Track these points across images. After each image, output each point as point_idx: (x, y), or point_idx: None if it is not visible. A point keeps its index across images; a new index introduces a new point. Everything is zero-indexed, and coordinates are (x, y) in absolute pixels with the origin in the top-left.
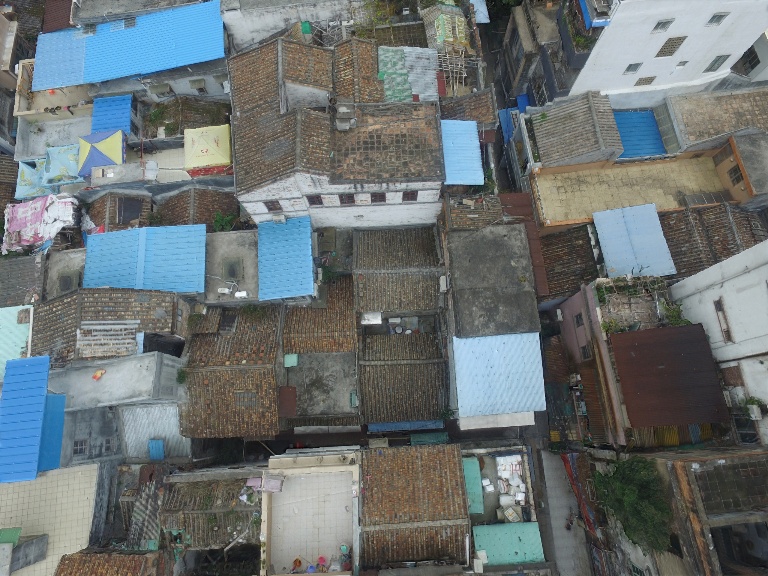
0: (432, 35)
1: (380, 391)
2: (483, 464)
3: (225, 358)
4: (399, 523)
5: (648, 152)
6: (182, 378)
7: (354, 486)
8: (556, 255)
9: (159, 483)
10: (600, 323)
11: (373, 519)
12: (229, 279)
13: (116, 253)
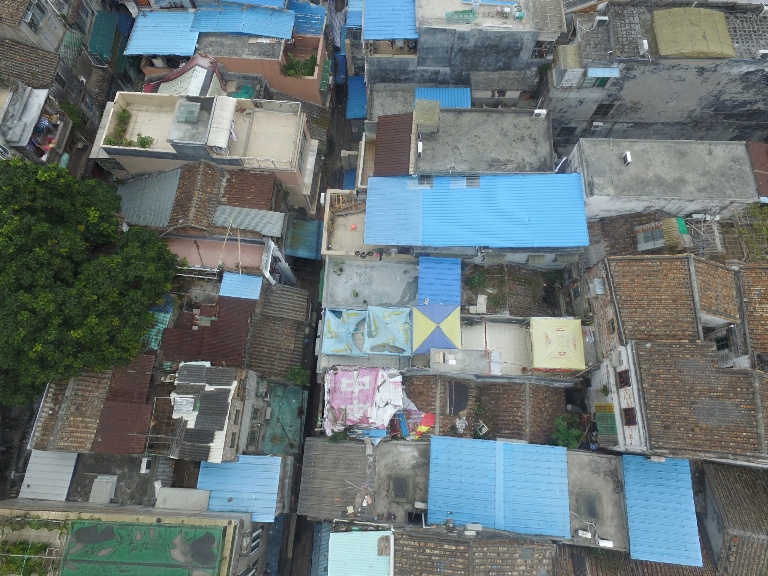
0: None
1: None
2: None
3: None
4: None
5: None
6: None
7: None
8: None
9: None
10: None
11: None
12: (590, 519)
13: (467, 467)
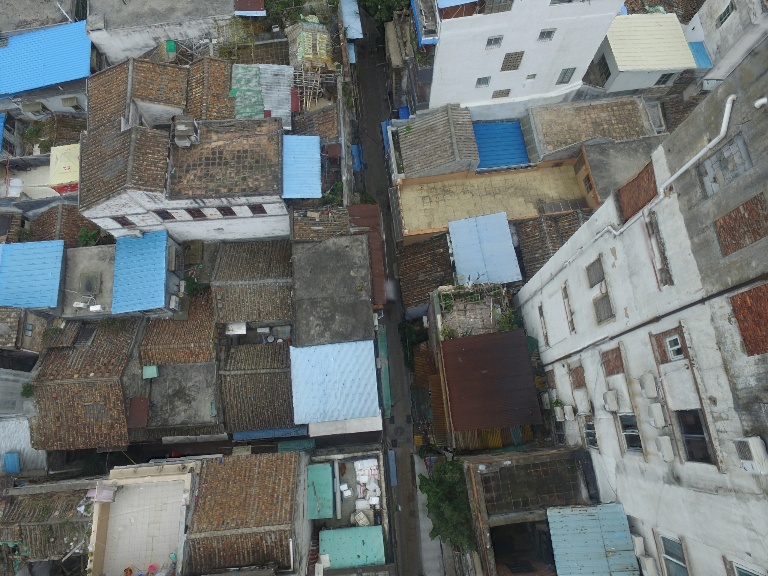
0: (294, 52)
1: (241, 400)
2: (344, 470)
3: (75, 371)
4: (224, 530)
5: (511, 162)
6: (27, 392)
7: (185, 495)
8: (420, 263)
9: (1, 496)
10: (439, 330)
11: (201, 527)
12: (85, 293)
13: None
